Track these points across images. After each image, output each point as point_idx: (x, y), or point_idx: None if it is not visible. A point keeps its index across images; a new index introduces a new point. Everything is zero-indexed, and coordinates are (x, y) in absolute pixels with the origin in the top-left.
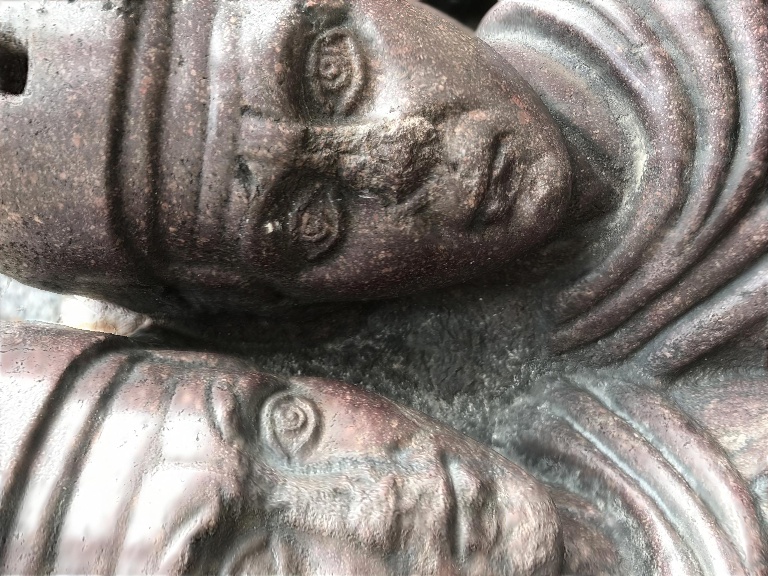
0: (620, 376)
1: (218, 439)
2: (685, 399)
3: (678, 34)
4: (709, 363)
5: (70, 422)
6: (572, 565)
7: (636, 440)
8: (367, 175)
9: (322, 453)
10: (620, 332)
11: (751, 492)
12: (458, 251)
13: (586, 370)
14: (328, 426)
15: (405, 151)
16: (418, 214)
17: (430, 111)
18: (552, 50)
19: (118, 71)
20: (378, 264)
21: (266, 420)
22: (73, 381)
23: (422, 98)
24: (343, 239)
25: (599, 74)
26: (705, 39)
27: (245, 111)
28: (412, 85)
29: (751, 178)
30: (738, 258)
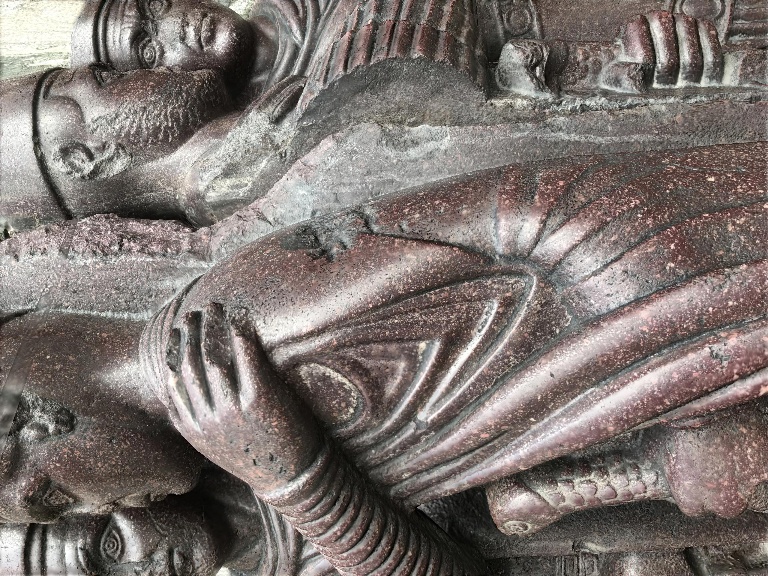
0: None
1: (86, 574)
2: None
3: None
4: None
5: (36, 575)
6: (240, 537)
7: None
8: None
9: (126, 557)
10: None
11: None
12: None
13: None
14: (126, 543)
15: None
16: None
17: None
18: None
19: None
20: None
21: (102, 550)
22: (29, 559)
23: None
24: None
25: None
26: None
27: None
28: (96, 498)
29: None
30: None
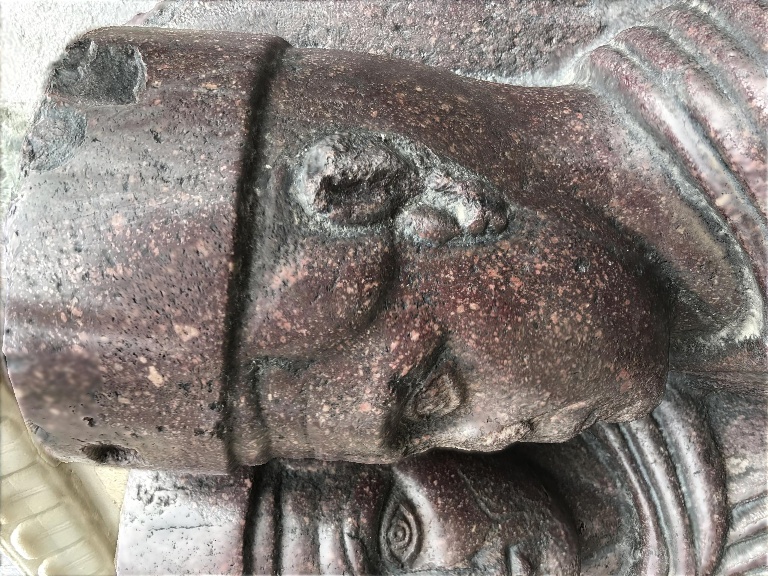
0: (669, 379)
1: None
2: (717, 408)
3: None
4: None
5: None
6: (586, 536)
7: (660, 455)
8: None
9: (424, 558)
10: None
11: (728, 514)
12: None
13: None
14: (426, 532)
15: None
16: None
17: None
18: (701, 201)
19: (227, 461)
20: None
21: (384, 543)
22: (251, 552)
23: (521, 415)
24: None
25: None
26: None
27: None
28: (512, 404)
29: None
30: None
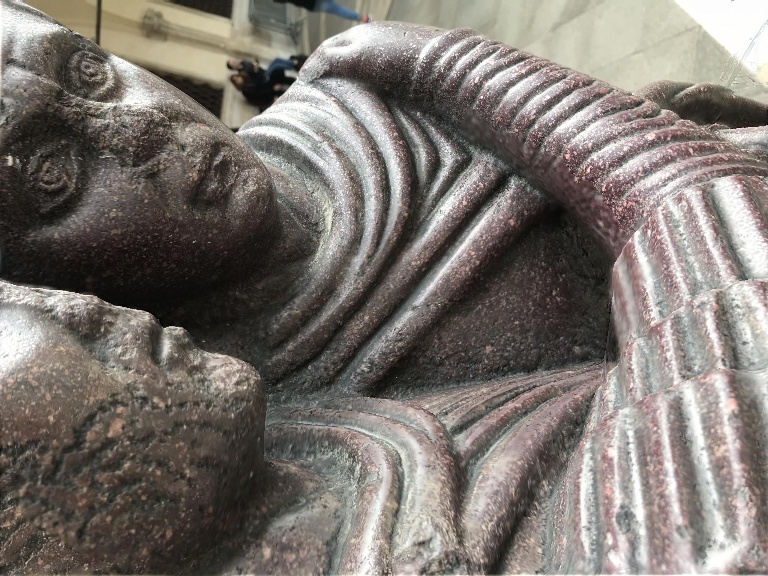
0: (329, 396)
1: None
2: None
3: (346, 135)
4: (400, 382)
5: None
6: (280, 470)
7: None
8: (109, 136)
9: None
10: (326, 355)
11: None
12: (182, 224)
13: (300, 397)
14: None
15: (144, 122)
16: (150, 179)
17: (167, 111)
18: (265, 157)
19: None
20: (108, 223)
21: None
22: None
23: (161, 102)
24: (78, 197)
25: (298, 166)
26: (362, 137)
27: (11, 62)
28: (154, 96)
29: (402, 217)
30: (405, 280)
